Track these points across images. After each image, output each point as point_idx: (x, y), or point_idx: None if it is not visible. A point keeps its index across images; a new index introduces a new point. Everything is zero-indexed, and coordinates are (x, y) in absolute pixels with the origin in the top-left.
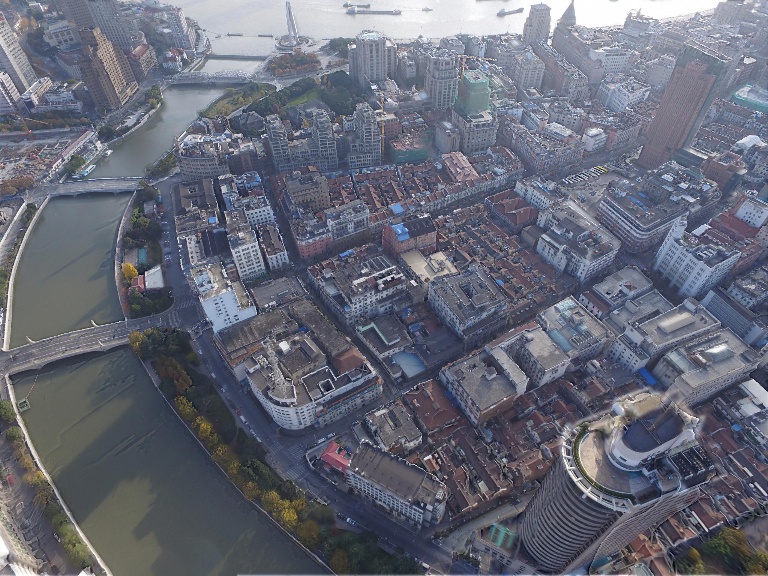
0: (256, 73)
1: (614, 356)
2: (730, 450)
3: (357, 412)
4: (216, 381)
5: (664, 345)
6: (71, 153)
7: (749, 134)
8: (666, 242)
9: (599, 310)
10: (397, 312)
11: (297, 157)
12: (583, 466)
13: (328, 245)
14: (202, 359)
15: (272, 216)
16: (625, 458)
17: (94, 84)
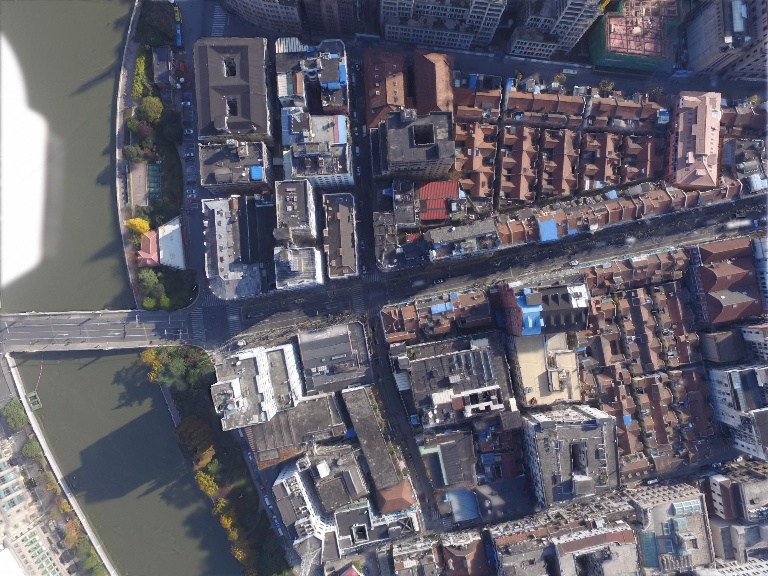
0: None
1: None
2: None
3: None
4: (243, 441)
5: None
6: None
7: None
8: None
9: (724, 514)
10: (475, 428)
11: (424, 11)
12: None
13: None
14: None
15: (351, 179)
16: None
17: None
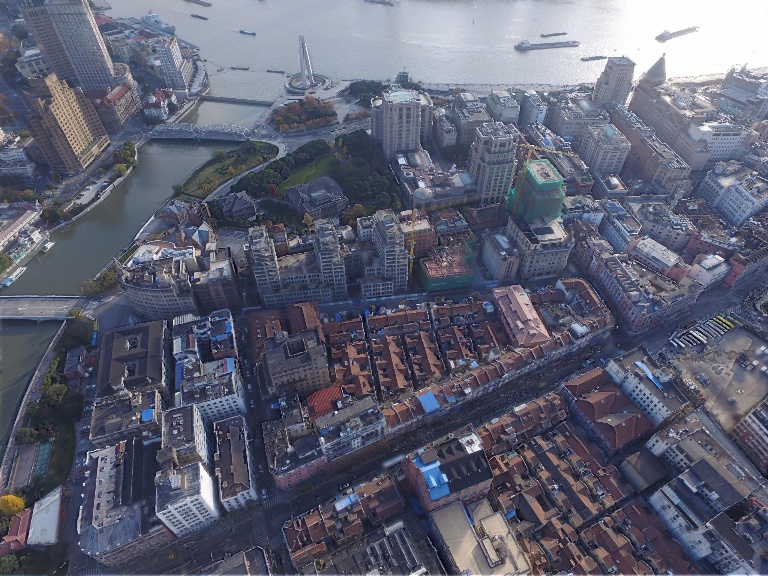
0: (257, 126)
1: None
2: None
3: None
4: None
5: None
6: None
7: None
8: None
9: None
10: None
11: (290, 282)
12: None
13: (320, 467)
14: None
15: (240, 403)
16: None
17: (46, 144)
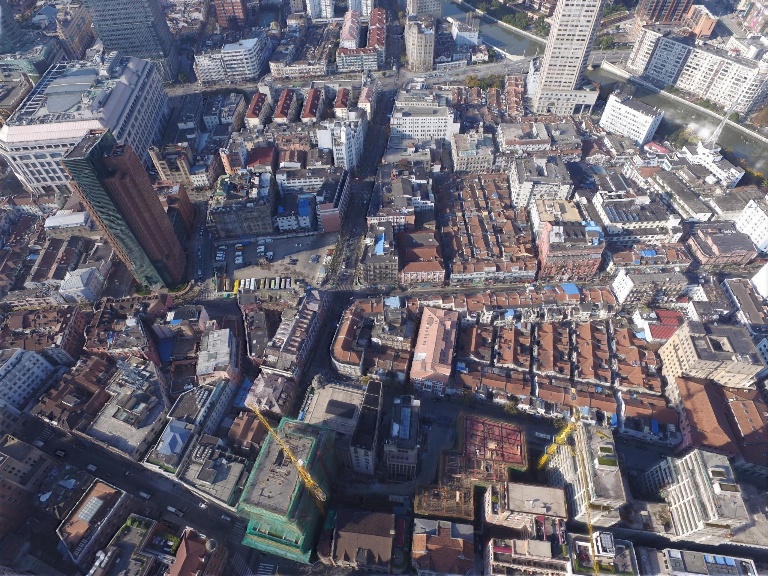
0: None
1: None
2: None
3: None
4: None
5: None
6: None
7: (2, 254)
8: None
9: None
10: None
11: None
12: None
13: None
14: None
15: None
16: None
17: None
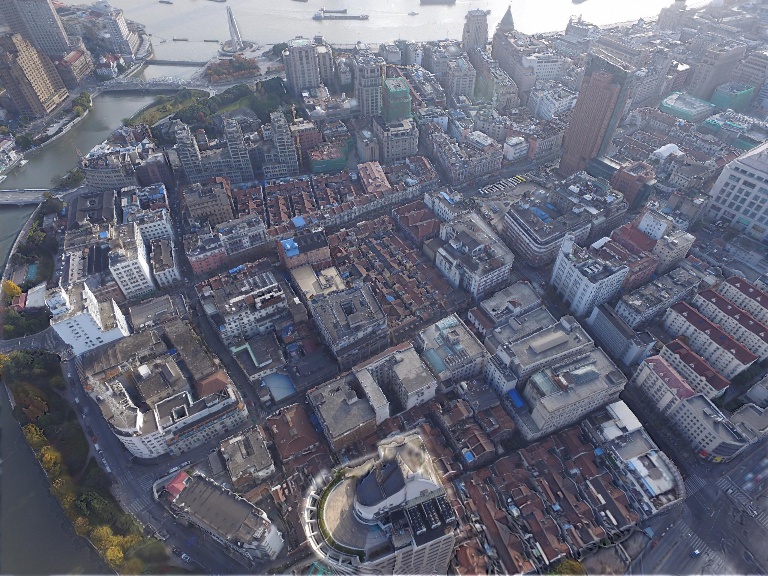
0: (193, 79)
1: (488, 376)
2: (588, 476)
3: (219, 438)
4: (78, 406)
5: (532, 366)
6: None
7: (672, 142)
8: (558, 256)
9: (483, 327)
10: (277, 331)
11: (209, 167)
12: (324, 518)
13: (223, 260)
14: (69, 382)
15: (169, 230)
16: (361, 511)
17: (15, 92)
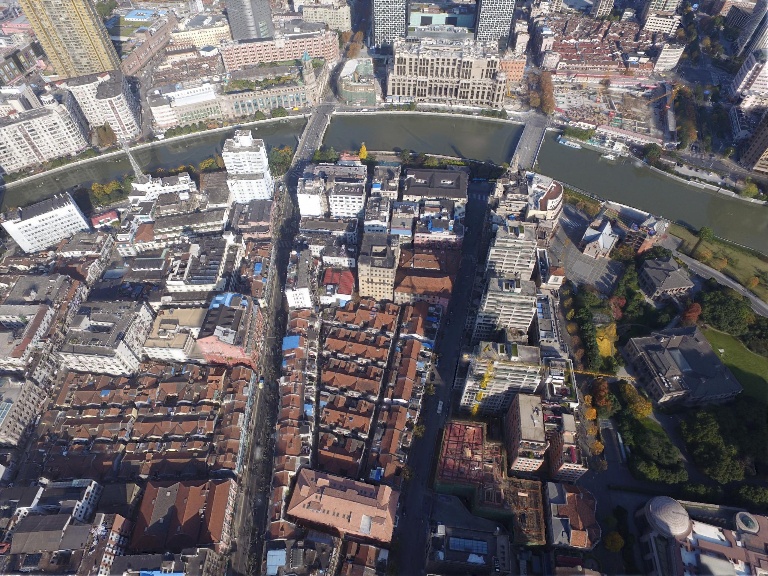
0: None
1: None
2: None
3: None
4: None
5: None
6: (611, 132)
7: None
8: None
9: None
10: None
11: None
12: None
13: None
14: None
15: None
16: None
17: None
